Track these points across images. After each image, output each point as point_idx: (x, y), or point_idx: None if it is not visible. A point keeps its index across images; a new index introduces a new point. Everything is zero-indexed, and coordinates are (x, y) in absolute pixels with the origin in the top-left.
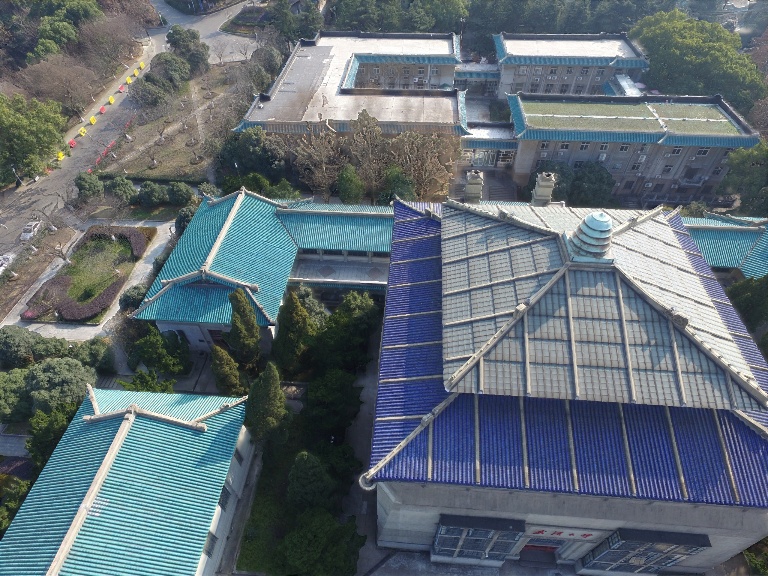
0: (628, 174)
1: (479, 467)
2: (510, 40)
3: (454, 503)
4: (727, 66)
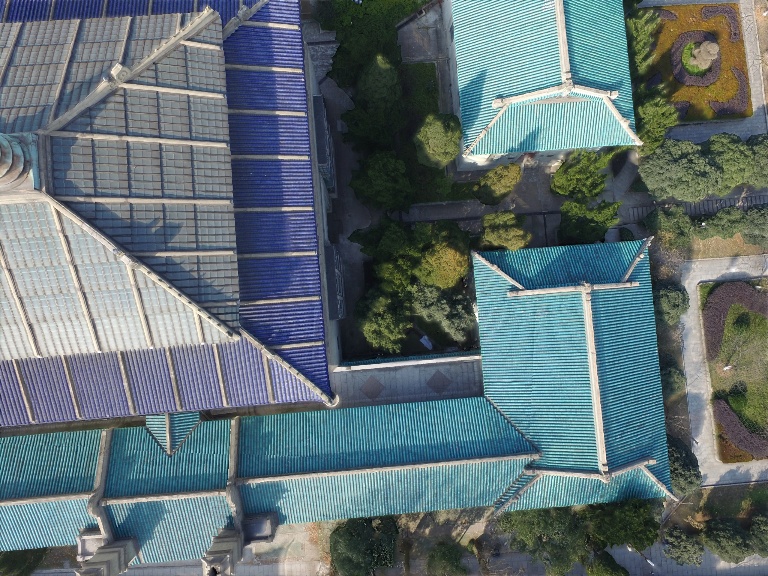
0: None
1: None
2: None
3: None
4: None
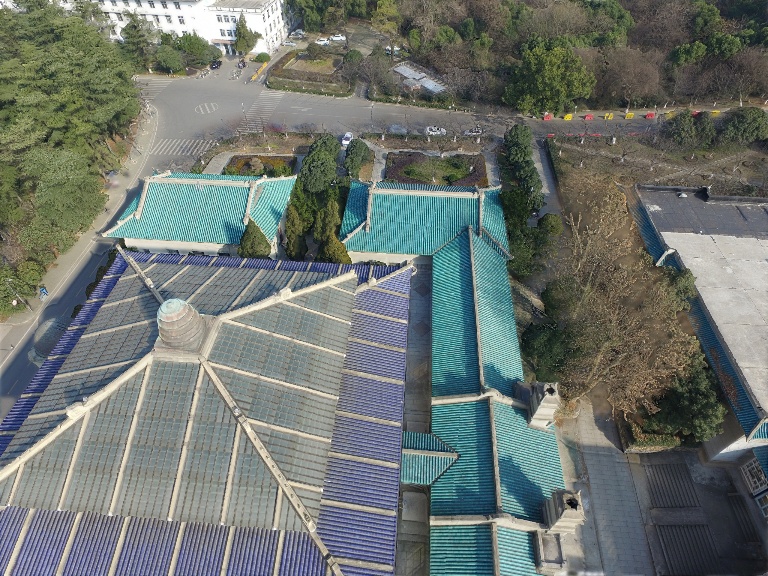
0: None
1: (94, 301)
2: None
3: None
4: None
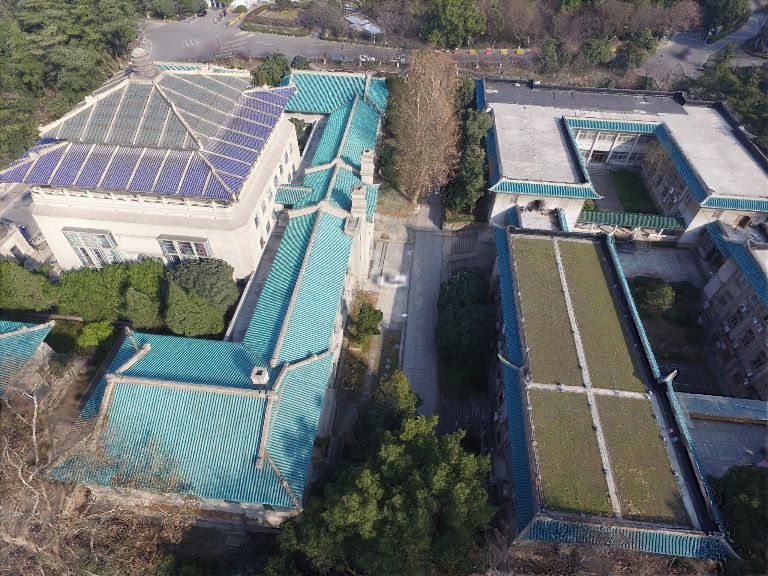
0: None
1: None
2: None
3: None
4: None
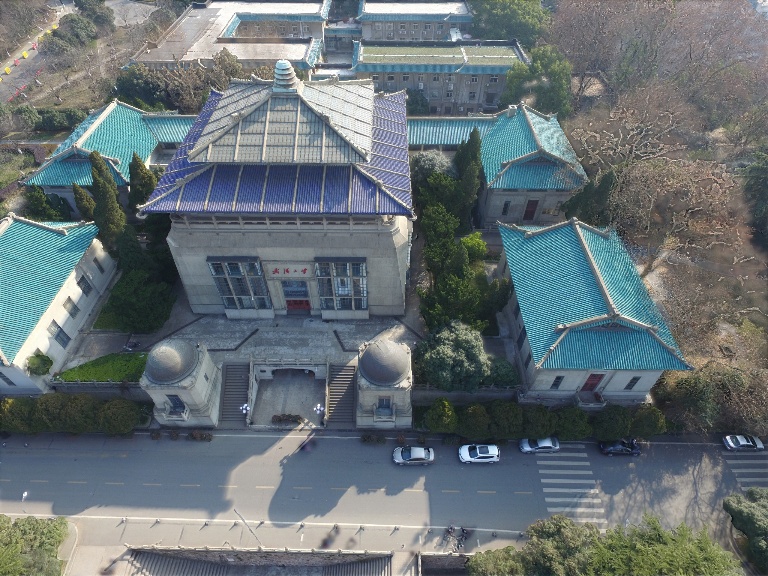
0: (445, 101)
1: (207, 203)
2: (372, 3)
3: (211, 244)
4: (522, 17)
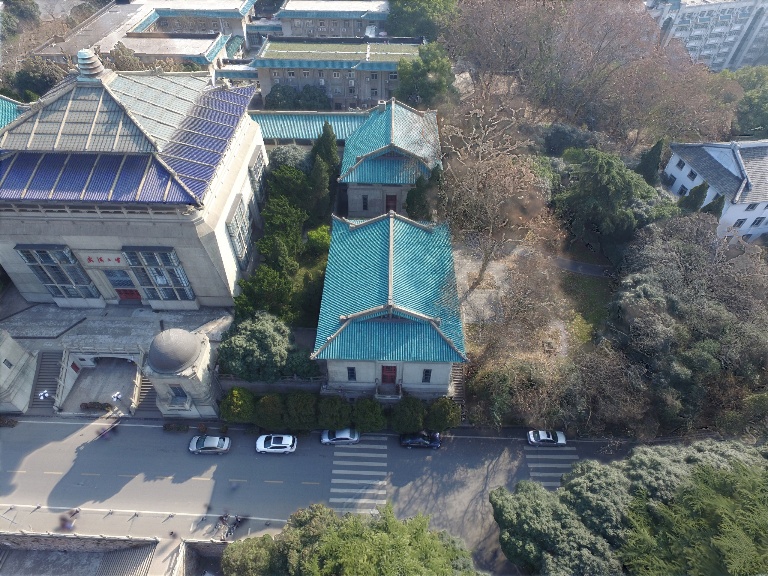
0: (349, 97)
1: None
2: (296, 0)
3: (16, 232)
4: (431, 14)
